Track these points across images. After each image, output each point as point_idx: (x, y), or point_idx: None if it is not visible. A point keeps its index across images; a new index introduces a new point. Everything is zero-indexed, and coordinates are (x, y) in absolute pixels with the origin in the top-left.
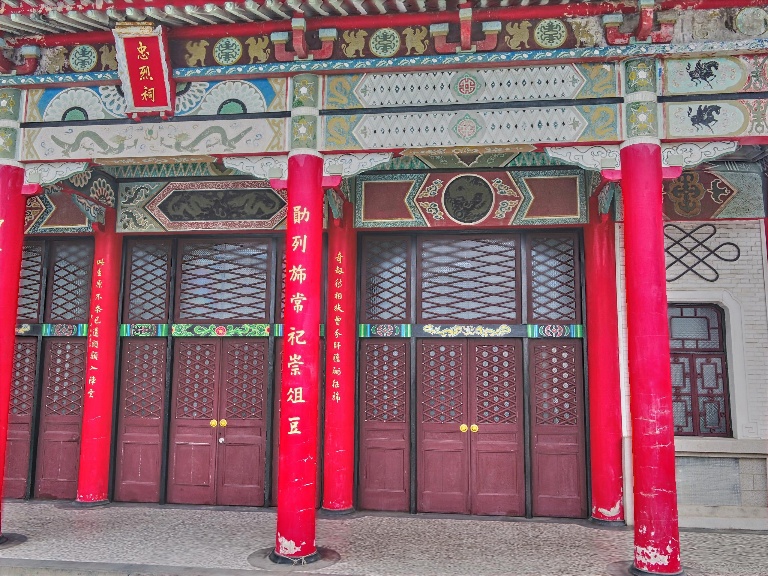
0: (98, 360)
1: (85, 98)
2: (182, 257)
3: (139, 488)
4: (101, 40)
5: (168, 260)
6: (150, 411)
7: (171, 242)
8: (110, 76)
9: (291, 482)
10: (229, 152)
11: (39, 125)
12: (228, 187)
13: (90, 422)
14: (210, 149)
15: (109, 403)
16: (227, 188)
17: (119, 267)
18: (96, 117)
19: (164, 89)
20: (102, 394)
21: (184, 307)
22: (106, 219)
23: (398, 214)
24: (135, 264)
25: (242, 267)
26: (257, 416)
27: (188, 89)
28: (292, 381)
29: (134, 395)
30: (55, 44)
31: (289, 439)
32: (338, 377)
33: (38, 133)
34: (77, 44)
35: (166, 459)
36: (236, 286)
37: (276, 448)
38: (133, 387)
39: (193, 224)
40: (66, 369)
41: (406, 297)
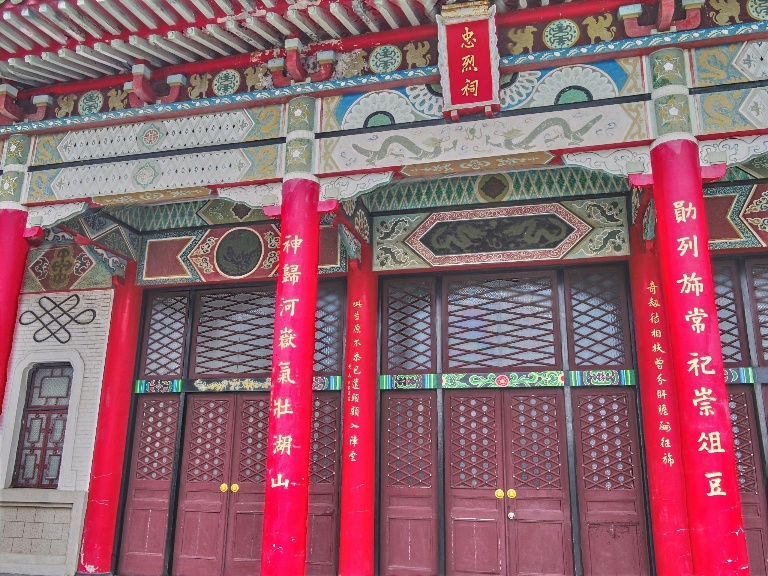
0: (359, 417)
1: (390, 101)
2: (447, 297)
3: (410, 575)
4: (406, 37)
5: (431, 301)
6: (418, 479)
7: (434, 280)
8: (423, 72)
9: (722, 564)
10: (575, 146)
11: (337, 134)
12: (502, 214)
13: (353, 491)
14: (550, 144)
15: (372, 468)
16: (501, 215)
17: (376, 310)
18: (404, 120)
19: (490, 80)
20: (365, 457)
21: (453, 354)
22: (362, 256)
23: (721, 234)
24: (392, 307)
25: (521, 305)
26: (555, 485)
27: (515, 80)
28: (703, 423)
29: (398, 459)
30: (353, 47)
31: (710, 503)
32: (668, 434)
33: (337, 143)
34: (378, 45)
35: (444, 538)
36: (515, 328)
37: (584, 526)
38: (396, 450)
39: (463, 257)
40: (316, 429)
41: (739, 334)
